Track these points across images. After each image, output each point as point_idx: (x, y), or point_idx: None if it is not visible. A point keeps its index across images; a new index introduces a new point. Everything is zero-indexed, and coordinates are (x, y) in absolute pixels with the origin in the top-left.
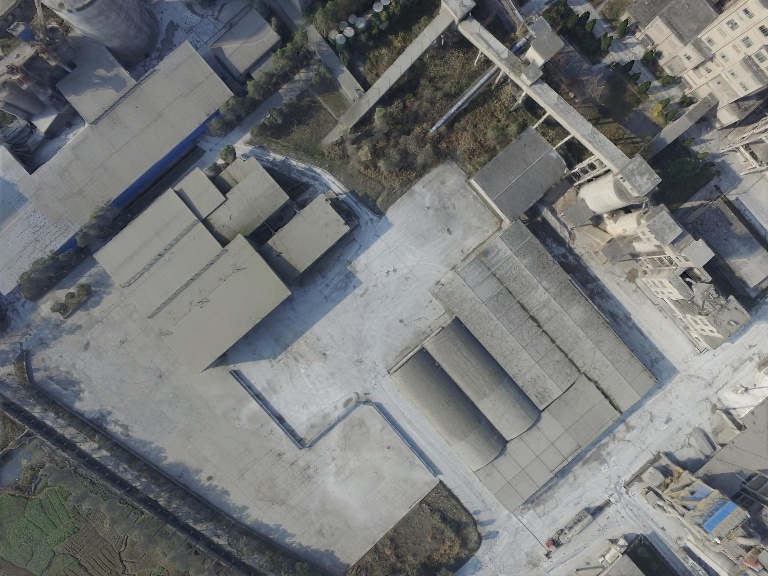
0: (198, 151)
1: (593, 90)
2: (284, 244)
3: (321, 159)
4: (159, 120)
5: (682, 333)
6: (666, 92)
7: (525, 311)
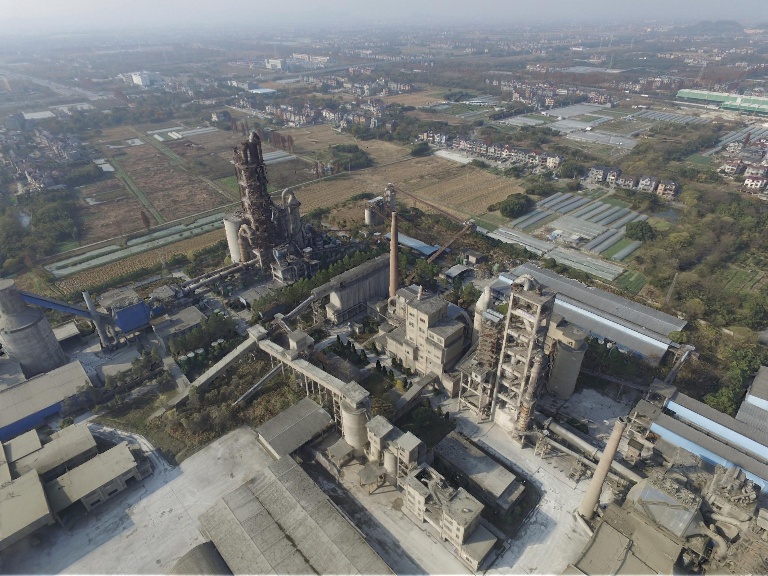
0: (46, 428)
1: (344, 369)
2: (71, 479)
3: (142, 429)
4: (26, 401)
5: (455, 559)
6: (411, 380)
7: (282, 531)
